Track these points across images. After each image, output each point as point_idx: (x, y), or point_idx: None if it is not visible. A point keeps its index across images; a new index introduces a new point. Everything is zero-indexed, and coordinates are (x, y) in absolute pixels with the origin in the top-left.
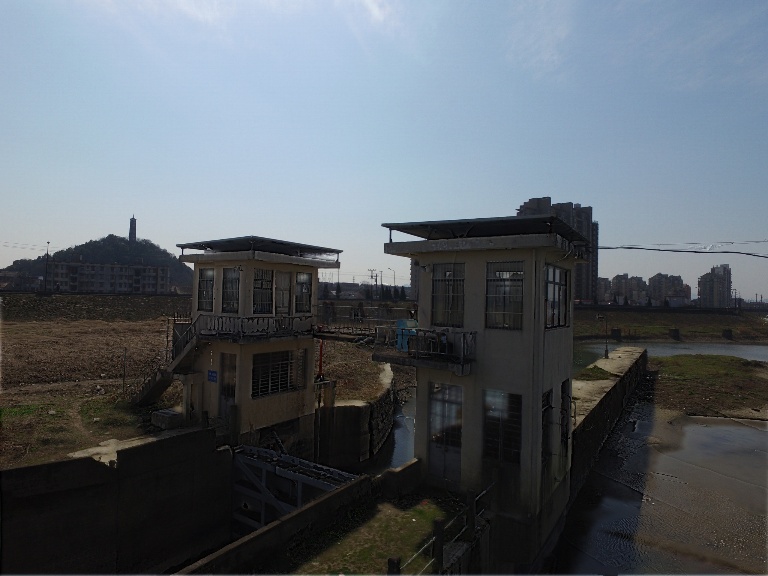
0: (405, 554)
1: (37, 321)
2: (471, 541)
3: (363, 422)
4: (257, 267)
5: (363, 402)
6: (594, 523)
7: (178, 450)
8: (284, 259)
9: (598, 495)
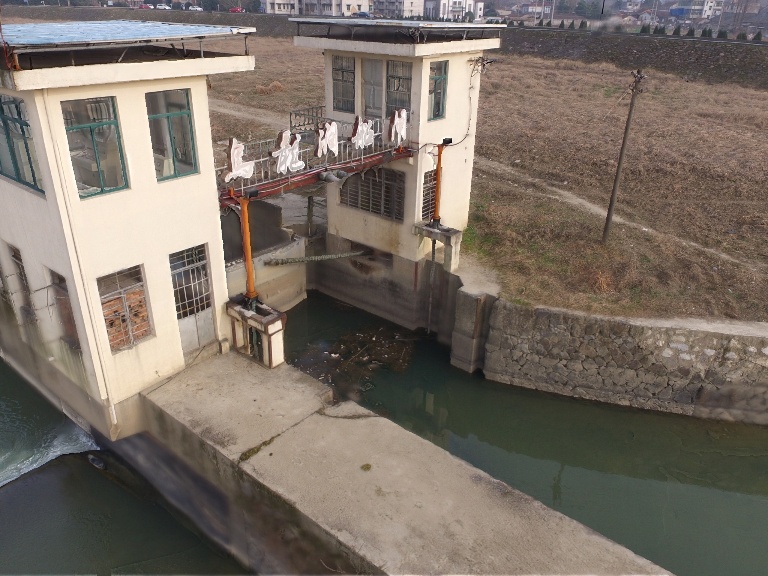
0: None
1: None
2: None
3: (462, 315)
4: (337, 53)
5: (487, 292)
6: None
7: (256, 210)
8: (327, 44)
9: None
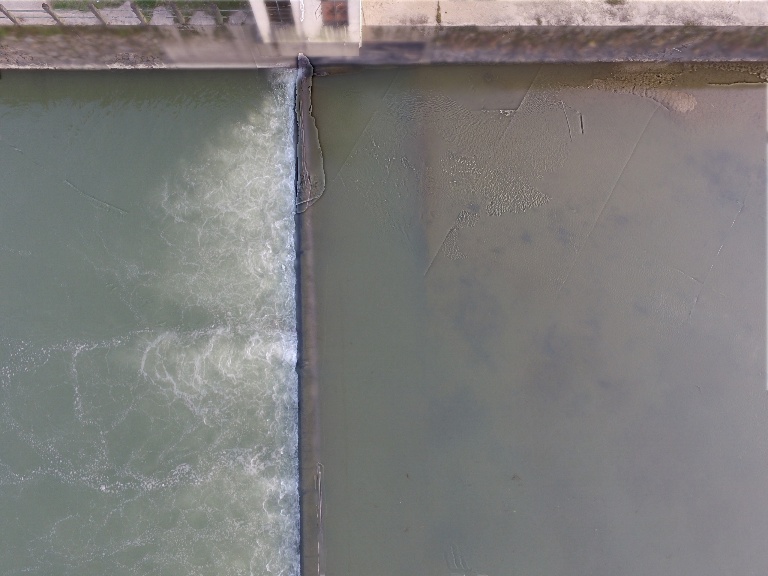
0: (184, 4)
1: None
2: (217, 24)
3: None
4: None
5: None
6: (432, 85)
7: None
8: None
9: (486, 79)
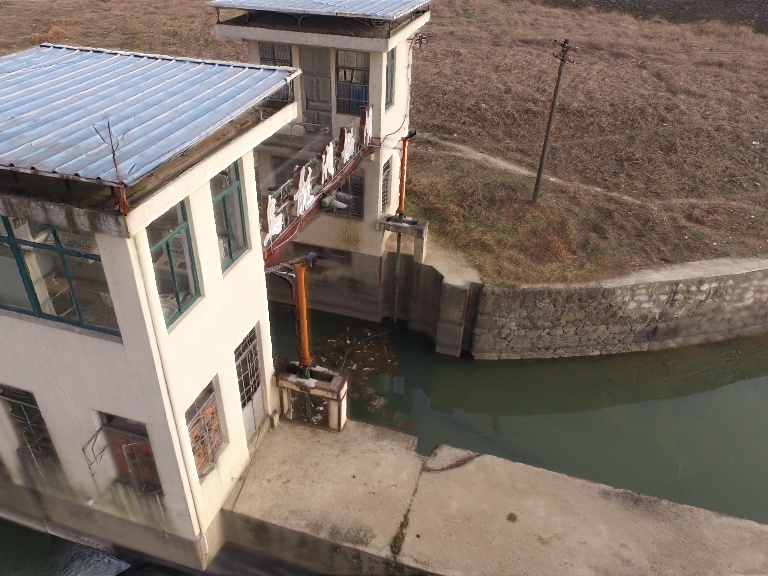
0: None
1: (569, 7)
2: None
3: (447, 306)
4: None
5: (470, 280)
6: None
7: None
8: (265, 35)
9: None
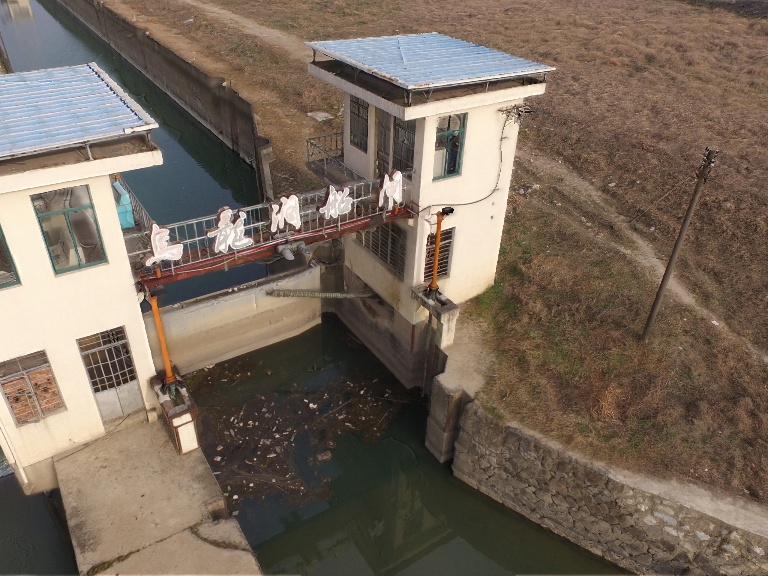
0: None
1: None
2: None
3: (436, 404)
4: None
5: (464, 389)
6: None
7: None
8: None
9: None
